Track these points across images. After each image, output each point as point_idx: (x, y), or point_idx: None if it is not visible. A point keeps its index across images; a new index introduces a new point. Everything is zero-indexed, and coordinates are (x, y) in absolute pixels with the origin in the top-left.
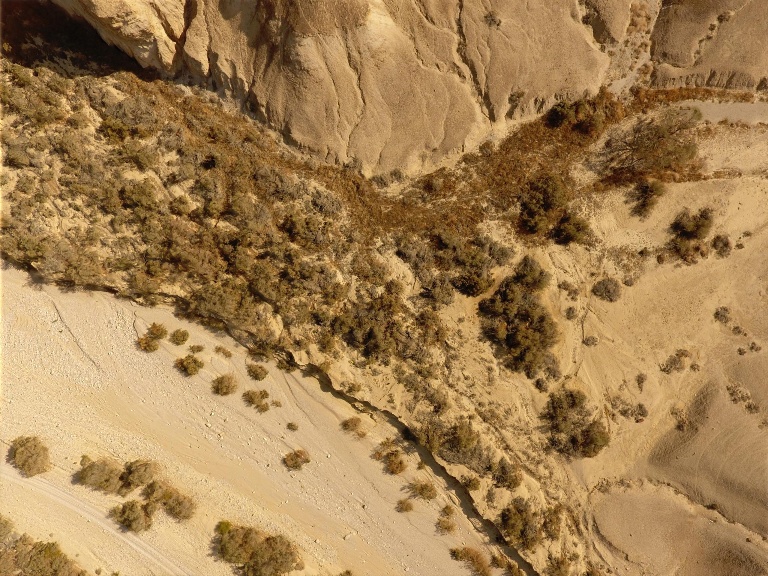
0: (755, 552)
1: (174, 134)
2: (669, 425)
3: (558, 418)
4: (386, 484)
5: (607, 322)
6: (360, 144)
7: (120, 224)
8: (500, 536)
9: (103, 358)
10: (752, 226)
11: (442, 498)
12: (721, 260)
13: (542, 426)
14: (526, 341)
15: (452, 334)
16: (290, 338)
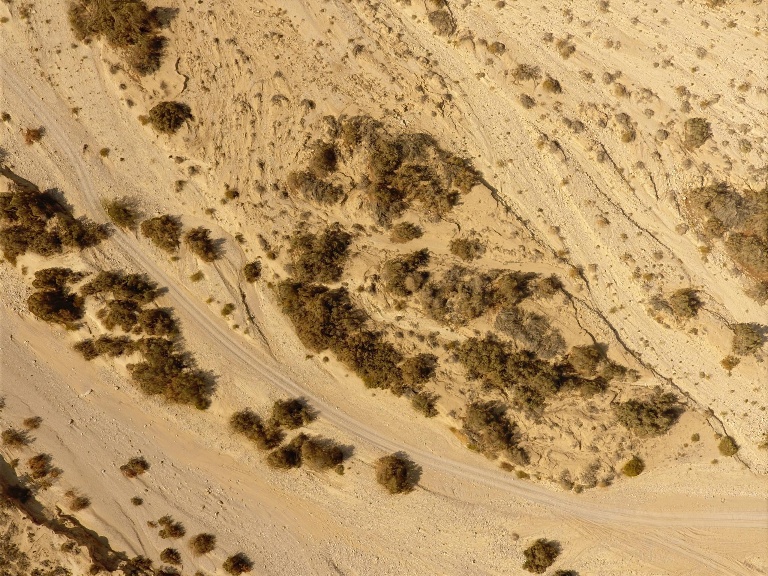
0: None
1: None
2: None
3: None
4: (49, 444)
5: None
6: None
7: None
8: None
9: (326, 573)
10: None
11: None
12: None
13: None
14: None
15: None
16: None
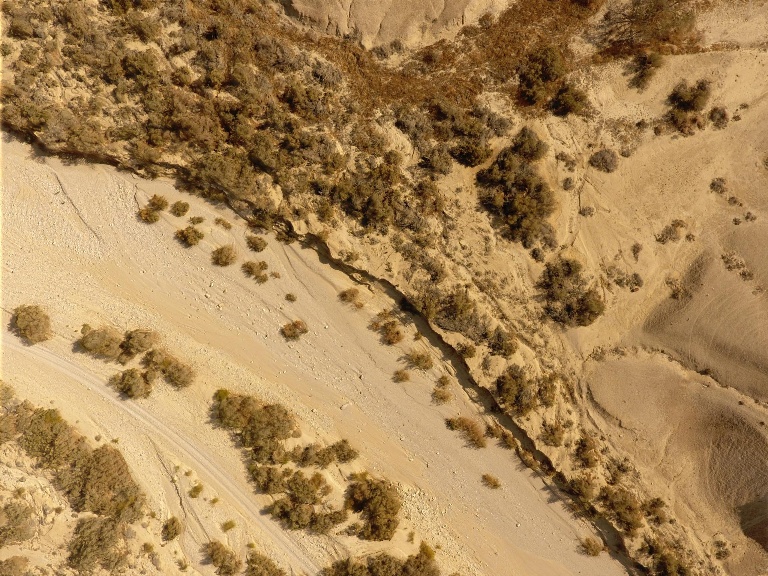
0: (747, 414)
1: (176, 5)
2: (664, 294)
3: (554, 286)
4: (383, 355)
5: (604, 193)
6: (361, 14)
7: (122, 93)
8: (495, 404)
9: (104, 229)
10: (749, 98)
11: (438, 369)
12: (718, 132)
13: (538, 295)
14: (523, 207)
15: (450, 204)
16: (289, 208)
